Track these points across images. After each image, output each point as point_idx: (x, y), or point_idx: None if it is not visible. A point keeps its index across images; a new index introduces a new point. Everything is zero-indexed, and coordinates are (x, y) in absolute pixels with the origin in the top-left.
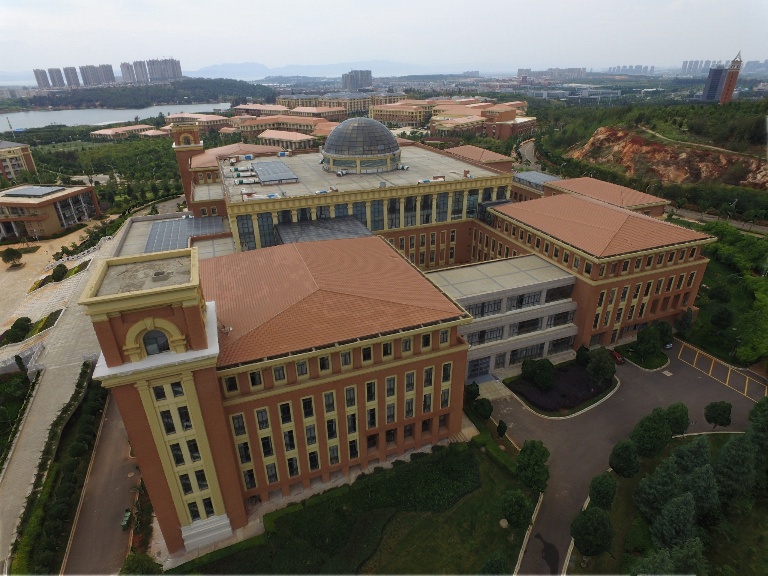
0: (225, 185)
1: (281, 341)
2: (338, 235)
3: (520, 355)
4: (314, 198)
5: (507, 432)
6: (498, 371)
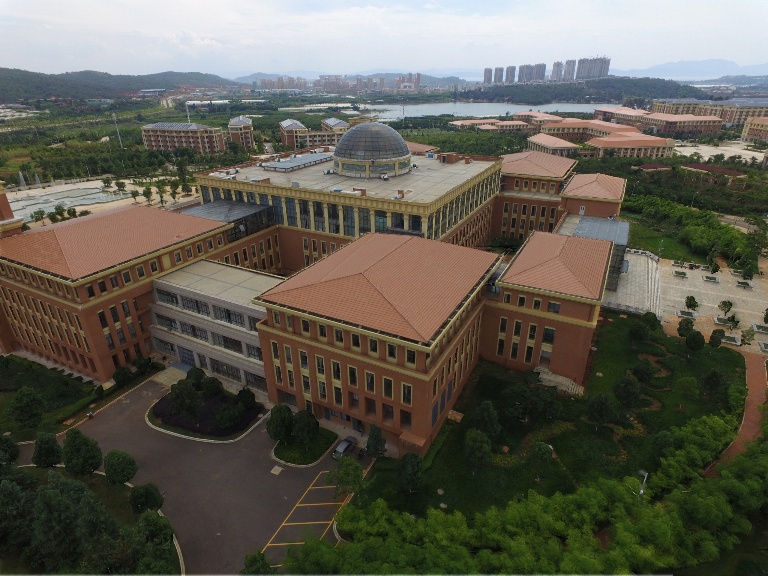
0: (248, 165)
1: (6, 249)
2: (217, 215)
3: (222, 368)
4: (244, 184)
5: (115, 402)
6: (204, 371)
